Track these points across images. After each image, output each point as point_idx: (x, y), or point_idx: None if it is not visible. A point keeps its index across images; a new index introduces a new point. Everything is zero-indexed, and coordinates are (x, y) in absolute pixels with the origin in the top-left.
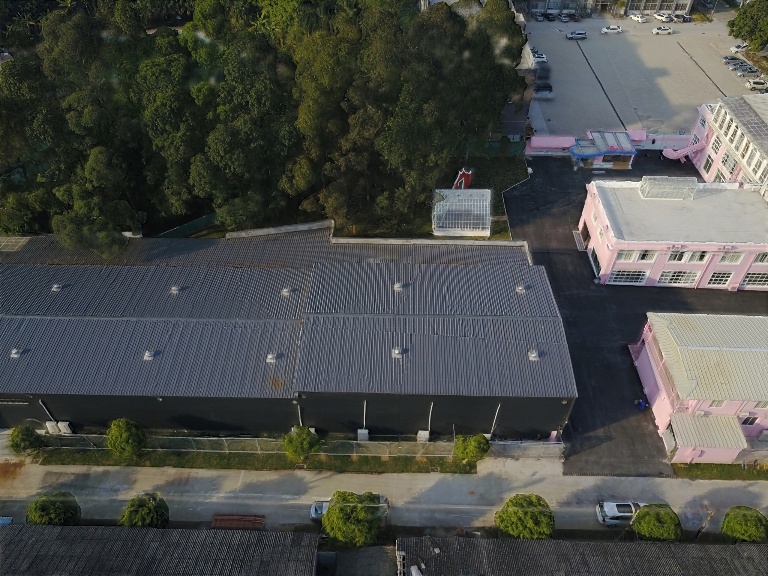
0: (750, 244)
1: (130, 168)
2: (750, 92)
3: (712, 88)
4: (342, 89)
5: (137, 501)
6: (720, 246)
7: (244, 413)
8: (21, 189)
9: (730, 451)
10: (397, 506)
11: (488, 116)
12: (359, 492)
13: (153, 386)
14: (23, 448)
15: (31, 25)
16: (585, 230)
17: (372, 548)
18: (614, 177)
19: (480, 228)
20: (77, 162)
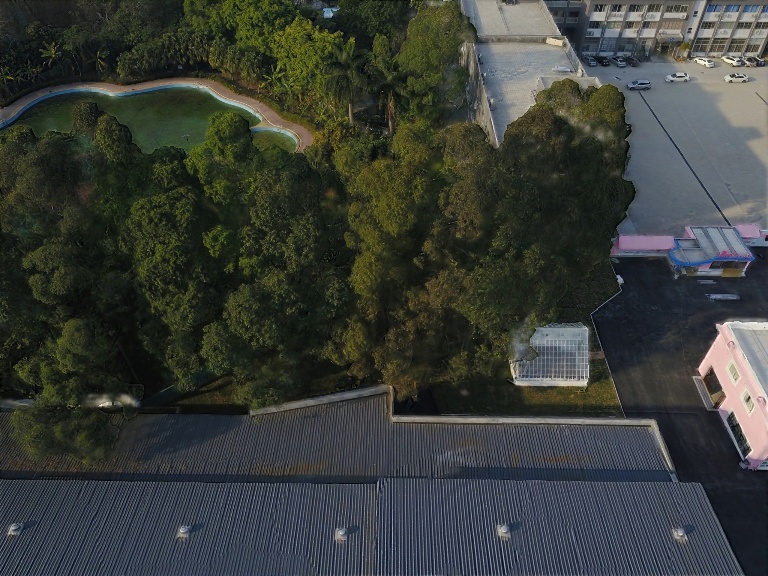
0: None
1: (120, 333)
2: None
3: None
4: (413, 232)
5: None
6: None
7: None
8: None
9: None
10: None
11: (599, 249)
12: None
13: None
14: None
15: (9, 80)
16: (713, 380)
17: None
18: (726, 289)
19: (576, 377)
20: (47, 333)
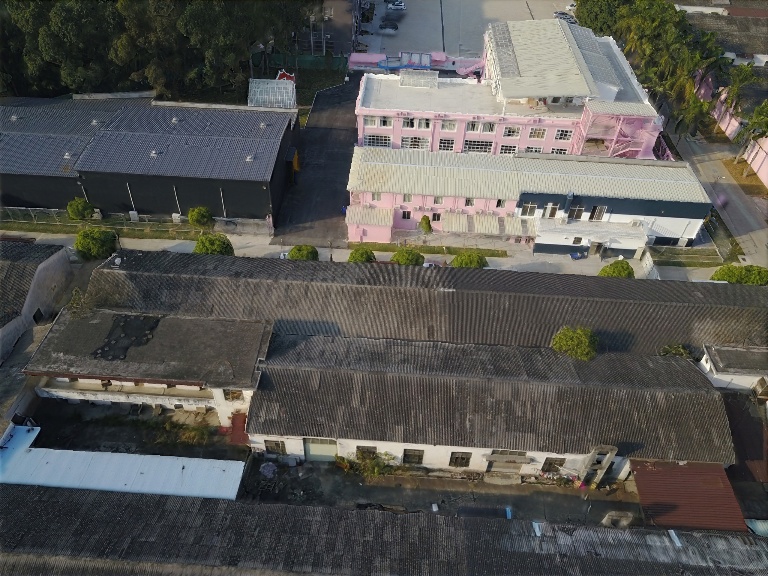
0: (458, 113)
1: None
2: None
3: None
4: None
5: None
6: (436, 114)
7: (46, 193)
8: None
9: (383, 230)
10: None
11: (276, 15)
12: None
13: None
14: None
15: None
16: None
17: (105, 260)
18: None
19: None
20: None
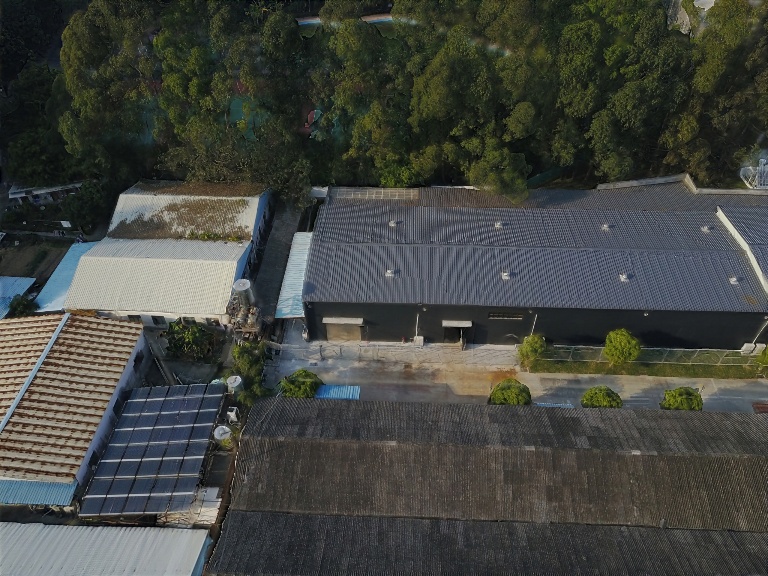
0: None
1: None
2: None
3: None
4: (736, 51)
5: (684, 391)
6: None
7: (711, 329)
8: (408, 145)
9: None
10: None
11: None
12: None
13: (644, 302)
14: (539, 353)
15: (264, 11)
16: None
17: None
18: None
19: None
20: (491, 117)
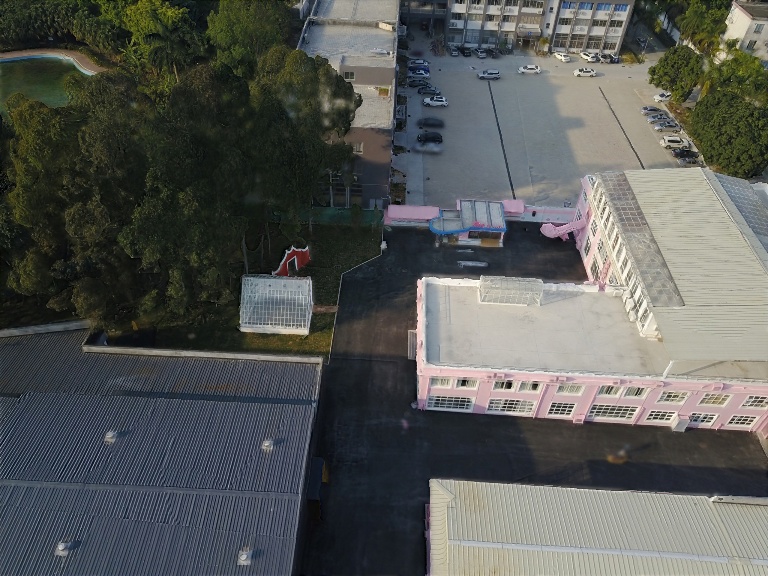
0: (589, 375)
1: None
2: (664, 151)
3: (623, 144)
4: None
5: None
6: (552, 377)
7: None
8: None
9: None
10: None
11: (285, 200)
12: None
13: None
14: None
15: None
16: None
17: None
18: (480, 257)
19: (294, 326)
20: None
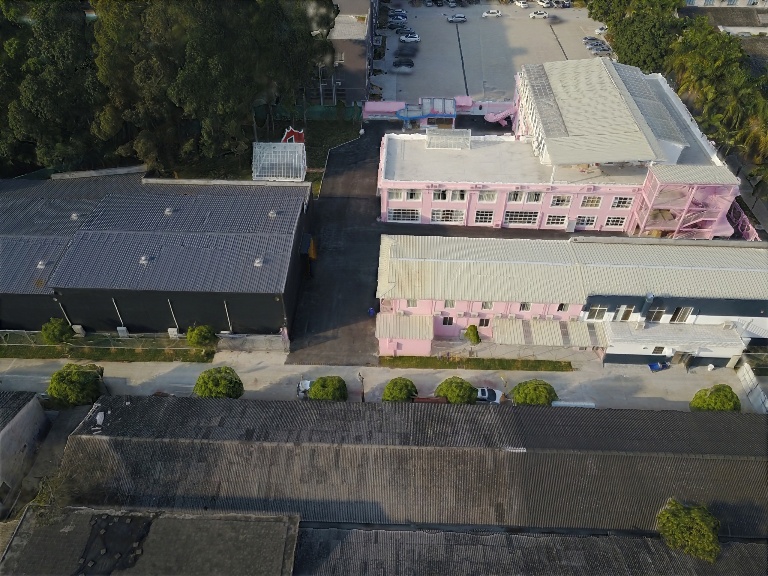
0: (498, 183)
1: None
2: None
3: None
4: None
5: None
6: (472, 185)
7: (18, 311)
8: None
9: (422, 343)
10: (135, 385)
11: (282, 73)
12: (107, 375)
13: None
14: None
15: None
16: None
17: (86, 406)
18: None
19: (292, 177)
20: None
